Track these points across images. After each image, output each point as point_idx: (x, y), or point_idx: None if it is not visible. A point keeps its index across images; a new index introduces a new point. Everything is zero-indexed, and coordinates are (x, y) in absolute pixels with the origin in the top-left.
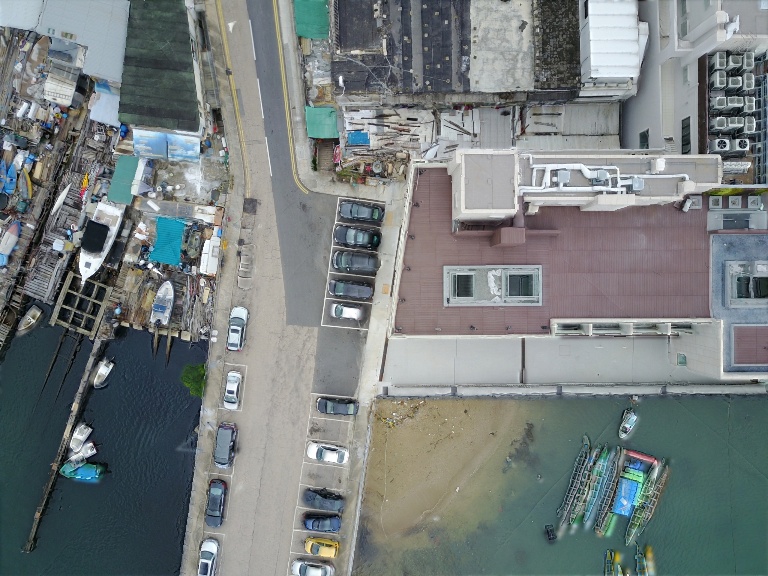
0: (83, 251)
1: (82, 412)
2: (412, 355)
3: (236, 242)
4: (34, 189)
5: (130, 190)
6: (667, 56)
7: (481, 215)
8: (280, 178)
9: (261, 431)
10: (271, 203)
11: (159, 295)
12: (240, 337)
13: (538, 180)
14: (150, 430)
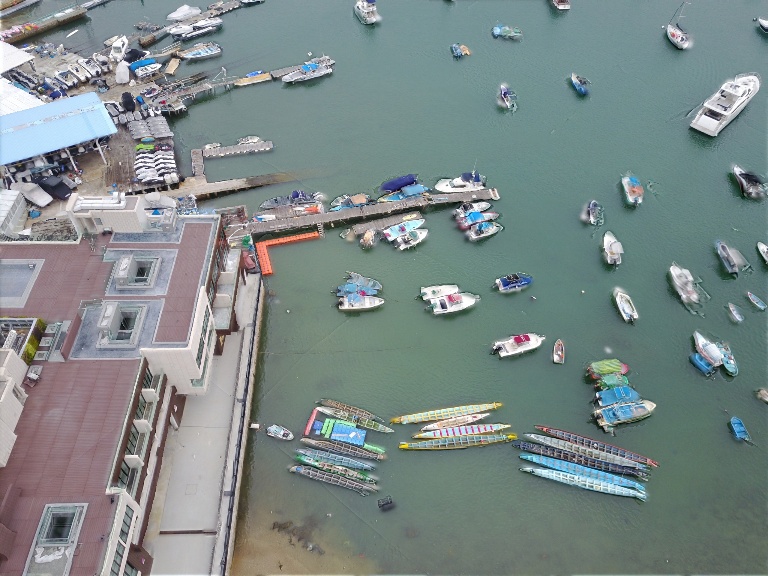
0: None
1: None
2: None
3: None
4: None
5: None
6: None
7: None
8: None
9: None
10: None
11: None
12: None
13: None
14: None
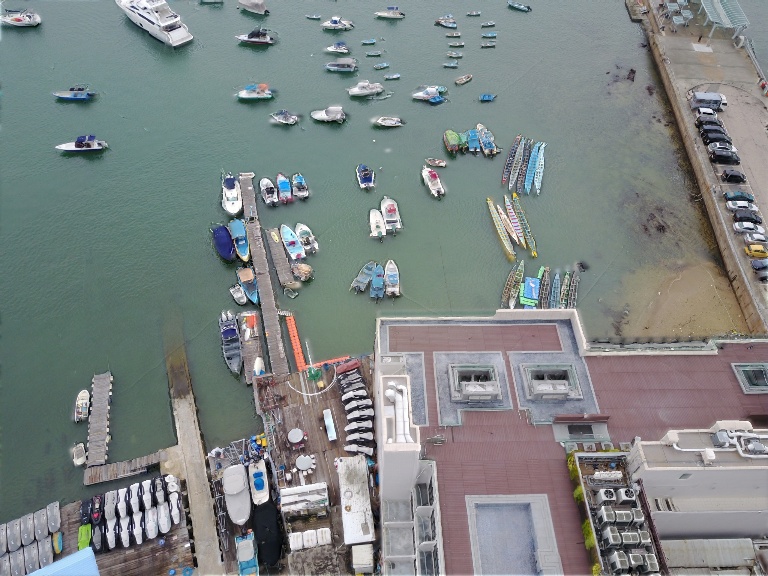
0: None
1: None
2: None
3: None
4: None
5: None
6: None
7: None
8: None
9: None
10: None
11: None
12: None
13: None
14: None
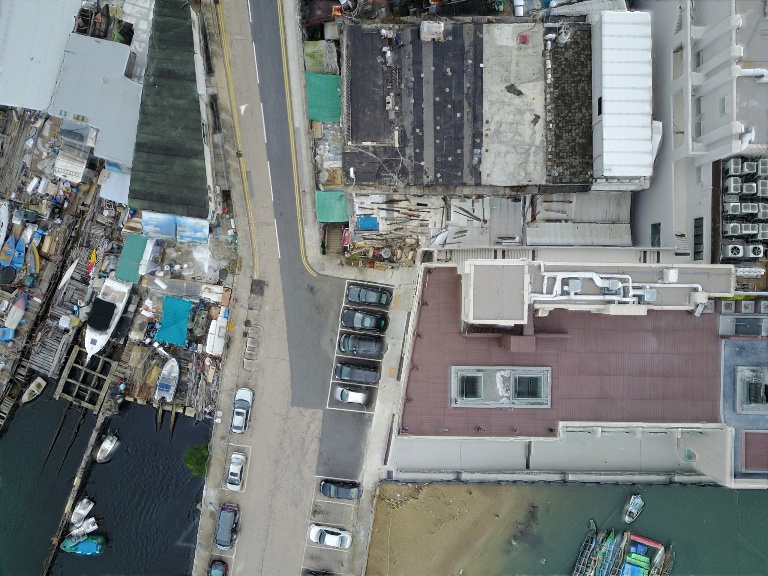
0: (89, 328)
1: (84, 485)
2: None
3: (243, 323)
4: (42, 263)
5: (138, 269)
6: (681, 156)
7: (491, 323)
8: (288, 260)
9: (264, 513)
10: (279, 285)
11: (164, 373)
12: (245, 420)
13: (549, 287)
14: (152, 503)
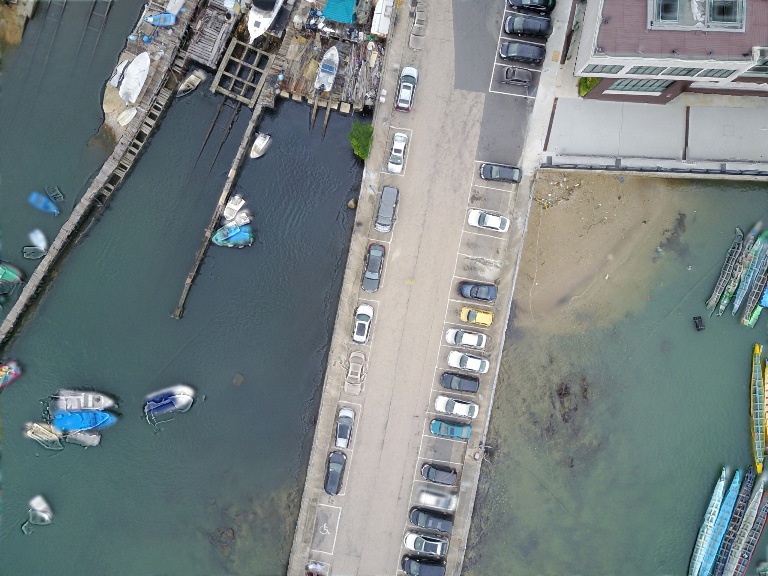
0: (253, 9)
1: (235, 184)
2: (578, 125)
3: (410, 2)
4: None
5: None
6: None
7: None
8: None
9: (422, 197)
10: None
11: None
12: (411, 94)
13: None
14: (298, 210)
